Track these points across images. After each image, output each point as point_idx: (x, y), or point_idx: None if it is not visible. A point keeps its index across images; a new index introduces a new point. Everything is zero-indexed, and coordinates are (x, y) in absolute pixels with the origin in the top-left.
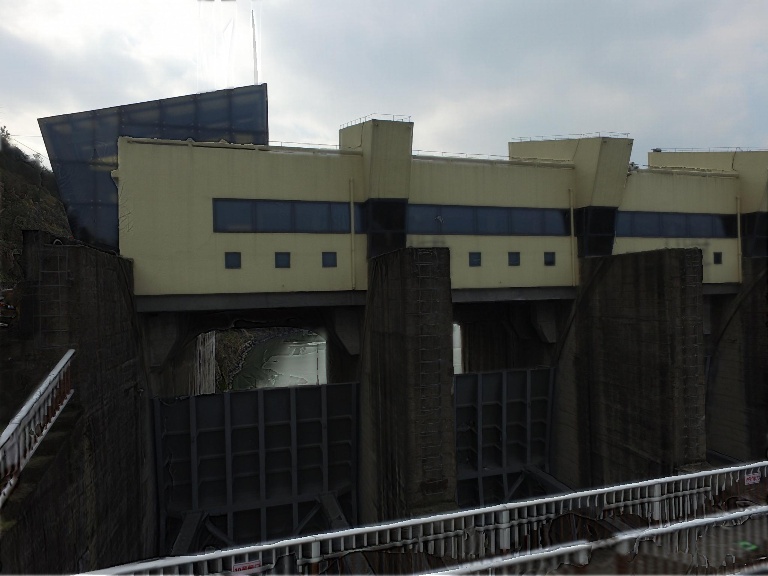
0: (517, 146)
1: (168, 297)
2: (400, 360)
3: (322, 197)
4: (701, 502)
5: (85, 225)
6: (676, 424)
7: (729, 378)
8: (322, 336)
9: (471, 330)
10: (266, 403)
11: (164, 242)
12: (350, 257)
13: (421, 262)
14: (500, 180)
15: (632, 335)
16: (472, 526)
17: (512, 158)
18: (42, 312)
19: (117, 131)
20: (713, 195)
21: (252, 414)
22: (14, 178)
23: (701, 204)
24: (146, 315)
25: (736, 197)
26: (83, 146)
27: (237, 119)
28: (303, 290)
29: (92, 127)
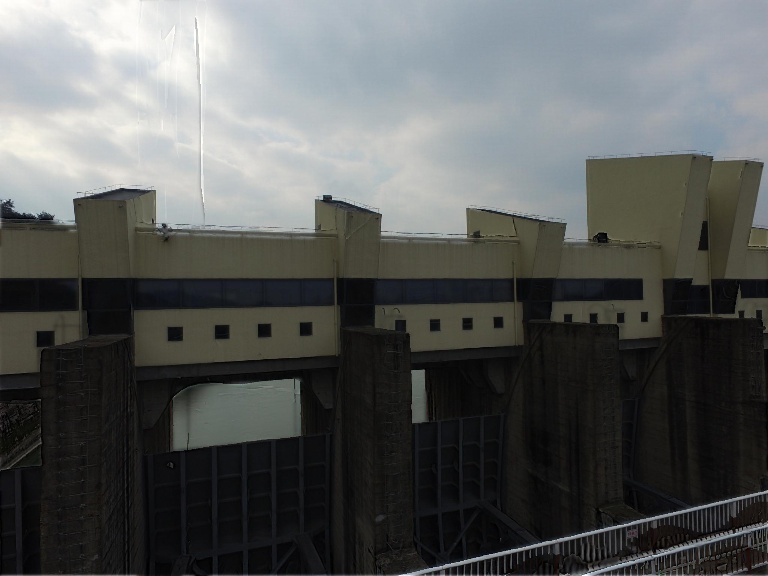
0: None
1: None
2: None
3: None
4: None
5: None
6: (43, 570)
7: (338, 461)
8: None
9: None
10: None
11: None
12: None
13: None
14: None
15: None
16: None
17: None
18: None
19: None
20: (301, 258)
21: None
22: None
23: (284, 268)
24: None
25: (333, 259)
26: None
27: None
28: None
29: None
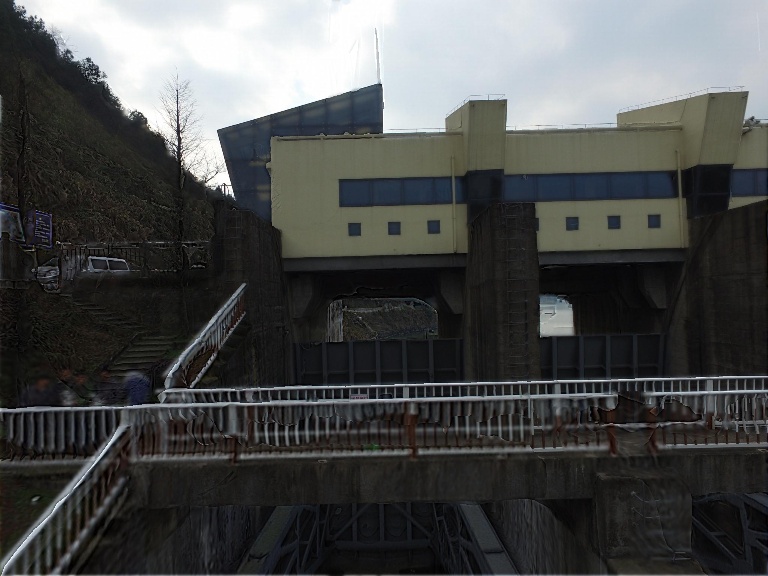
0: (625, 116)
1: (306, 259)
2: (491, 302)
3: (427, 174)
4: (760, 403)
5: (248, 208)
6: None
7: None
8: (432, 304)
9: (583, 307)
10: (382, 352)
11: (303, 216)
12: (452, 224)
13: (508, 215)
14: (598, 147)
15: (743, 290)
16: (528, 393)
17: (611, 125)
18: (226, 256)
19: (269, 134)
20: None
21: (371, 361)
22: (188, 195)
23: None
24: (290, 276)
25: None
26: (246, 148)
27: (358, 116)
28: (411, 253)
29: (252, 133)
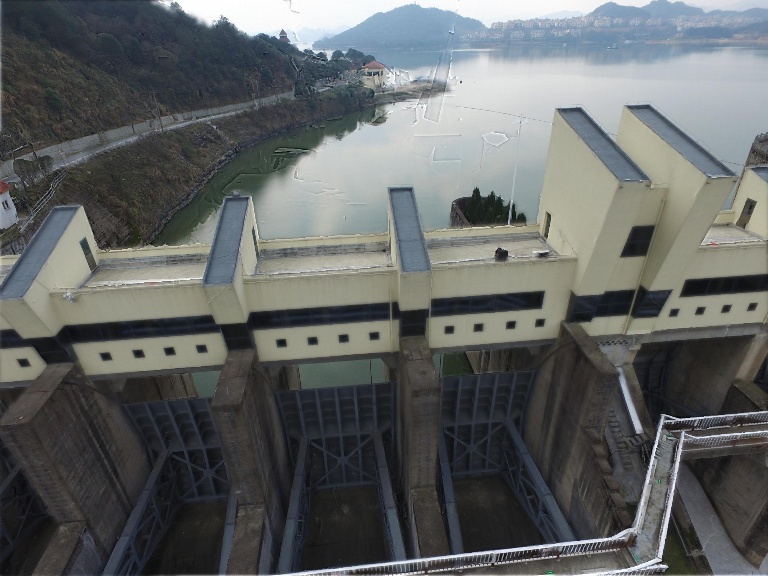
0: None
1: None
2: None
3: None
4: None
5: None
6: None
7: None
8: None
9: None
10: None
11: None
12: None
13: None
14: None
15: None
16: None
17: None
18: None
19: None
20: (185, 302)
21: None
22: None
23: (173, 310)
24: None
25: None
26: None
27: None
28: None
29: None
